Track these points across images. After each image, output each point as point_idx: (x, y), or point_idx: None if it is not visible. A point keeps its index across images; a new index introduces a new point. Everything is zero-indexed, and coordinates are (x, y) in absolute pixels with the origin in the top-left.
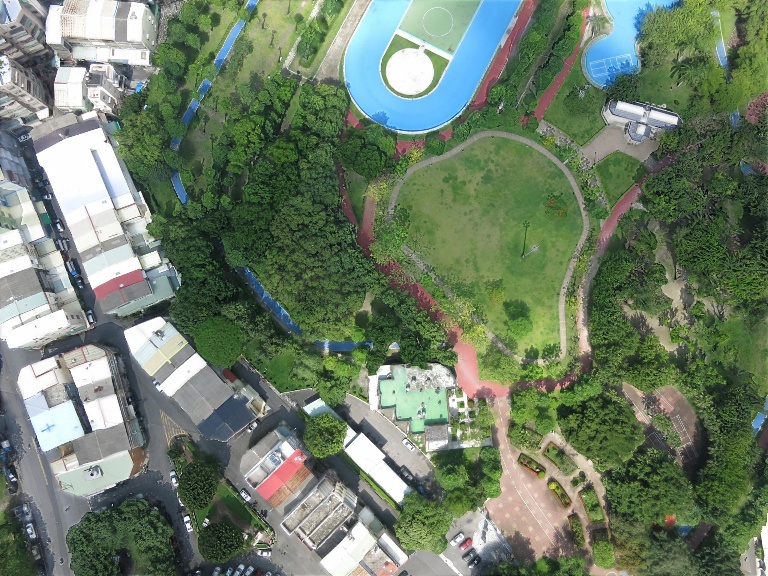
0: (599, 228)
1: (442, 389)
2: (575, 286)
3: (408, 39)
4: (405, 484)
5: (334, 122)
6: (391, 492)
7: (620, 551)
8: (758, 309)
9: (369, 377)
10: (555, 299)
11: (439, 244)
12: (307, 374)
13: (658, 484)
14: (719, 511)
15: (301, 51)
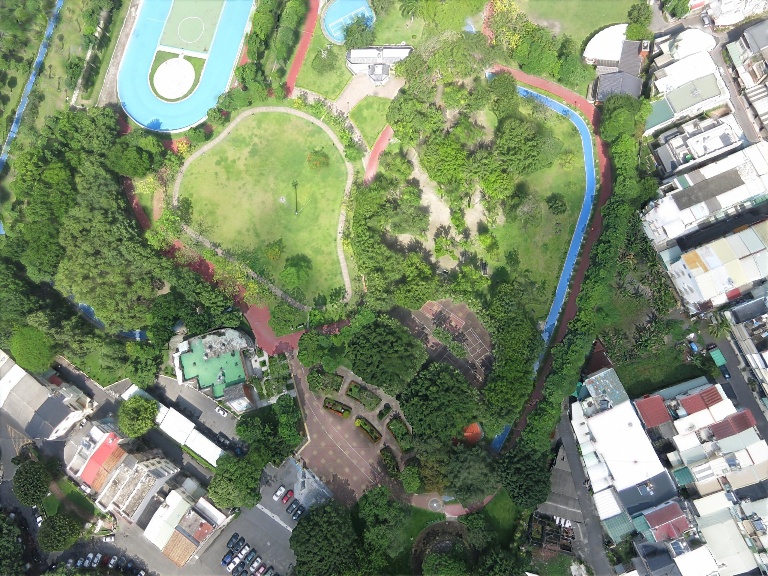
0: (363, 170)
1: (237, 351)
2: (349, 228)
3: (169, 52)
4: (219, 448)
5: (101, 137)
6: (208, 458)
7: (423, 472)
8: (513, 204)
9: (173, 355)
10: (333, 245)
11: (221, 221)
12: (107, 362)
13: (435, 395)
14: (505, 410)
15: (68, 85)
